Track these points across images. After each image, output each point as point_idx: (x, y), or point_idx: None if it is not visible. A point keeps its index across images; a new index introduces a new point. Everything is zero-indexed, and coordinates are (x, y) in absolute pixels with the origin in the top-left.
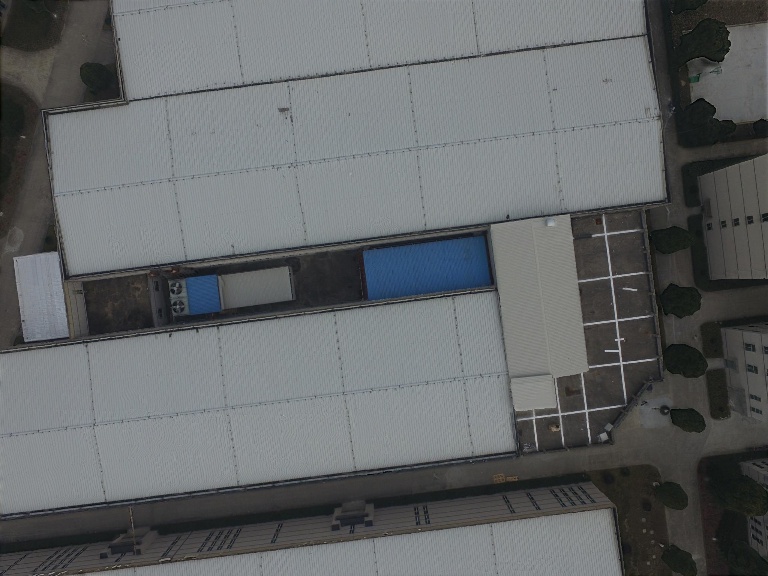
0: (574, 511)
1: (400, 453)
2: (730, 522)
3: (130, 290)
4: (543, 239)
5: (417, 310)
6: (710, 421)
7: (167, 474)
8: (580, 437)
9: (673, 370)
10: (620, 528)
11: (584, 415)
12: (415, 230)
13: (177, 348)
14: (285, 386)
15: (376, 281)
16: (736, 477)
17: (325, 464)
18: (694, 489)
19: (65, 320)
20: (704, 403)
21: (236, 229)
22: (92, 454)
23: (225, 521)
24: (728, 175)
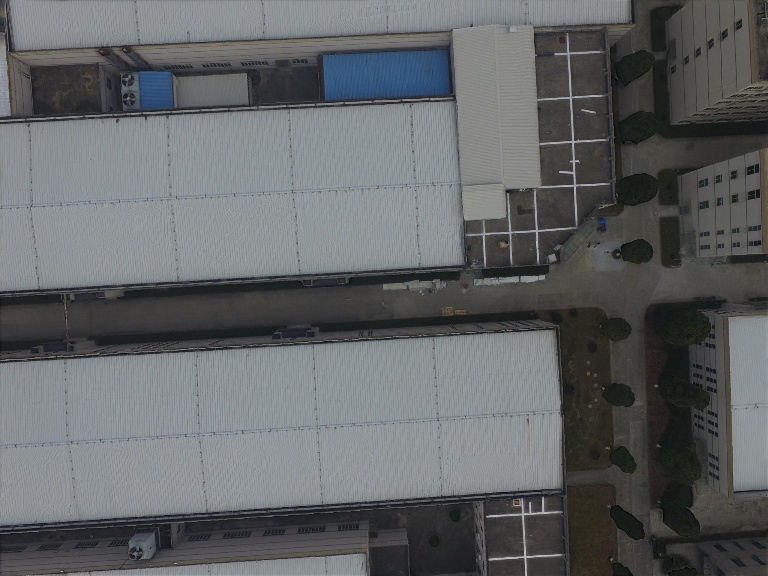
0: (517, 328)
1: (347, 262)
2: (673, 370)
3: (80, 80)
4: (505, 46)
5: (373, 113)
6: (661, 269)
7: (105, 268)
8: (528, 257)
9: (626, 198)
10: (564, 369)
11: (534, 235)
12: (377, 32)
13: (124, 134)
14: (233, 180)
15: (334, 86)
16: (680, 308)
17: (269, 268)
18: (640, 335)
19: (9, 105)
20: (656, 250)
21: (192, 12)
22: (27, 238)
23: (165, 335)
24: (694, 6)
